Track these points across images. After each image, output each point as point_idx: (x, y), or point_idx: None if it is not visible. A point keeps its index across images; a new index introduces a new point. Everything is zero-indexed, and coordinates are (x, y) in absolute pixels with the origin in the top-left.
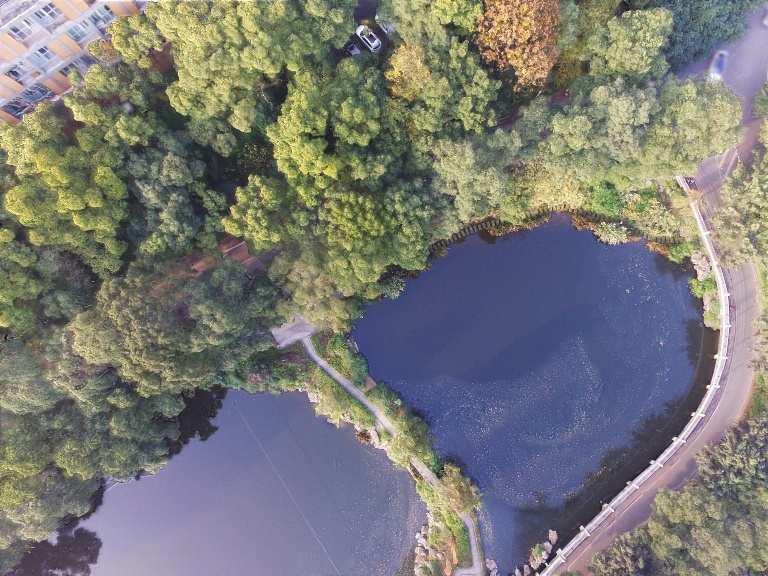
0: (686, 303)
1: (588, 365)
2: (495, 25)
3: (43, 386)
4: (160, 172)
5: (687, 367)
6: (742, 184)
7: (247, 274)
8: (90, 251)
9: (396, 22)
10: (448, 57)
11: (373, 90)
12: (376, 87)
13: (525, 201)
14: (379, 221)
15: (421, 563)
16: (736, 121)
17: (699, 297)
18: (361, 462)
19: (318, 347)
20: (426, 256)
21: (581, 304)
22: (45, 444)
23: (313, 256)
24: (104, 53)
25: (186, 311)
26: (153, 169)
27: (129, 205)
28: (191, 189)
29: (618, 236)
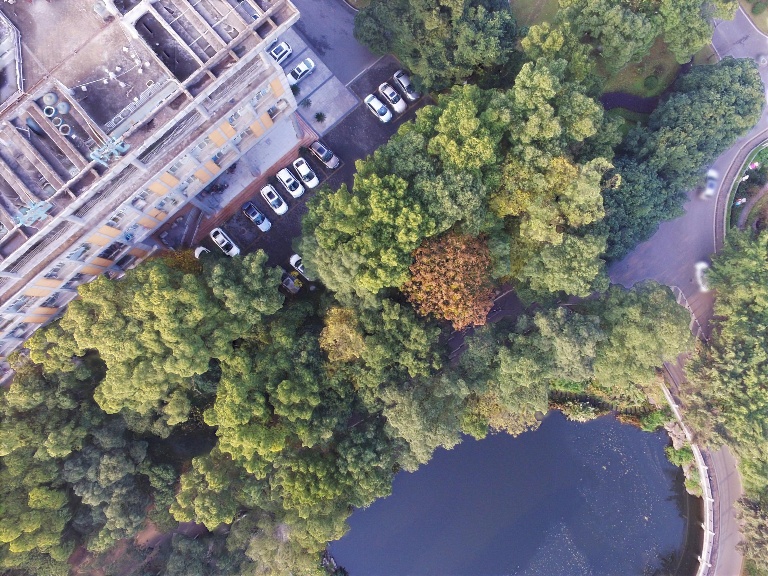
0: (665, 472)
1: (574, 551)
2: (424, 289)
3: None
4: (98, 475)
5: (677, 518)
6: (703, 365)
7: None
8: (34, 564)
9: None
10: (382, 317)
11: (309, 361)
12: (311, 358)
13: (484, 422)
14: (333, 486)
15: None
16: (684, 340)
17: (678, 466)
18: None
19: (294, 571)
20: (390, 483)
21: (559, 487)
22: None
23: (270, 526)
24: (24, 368)
25: None
26: (90, 475)
27: (70, 509)
28: (135, 471)
29: (586, 415)
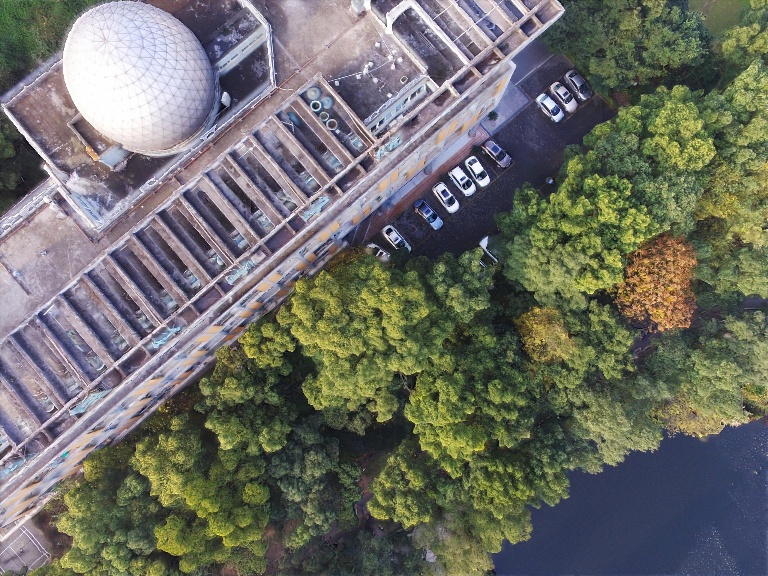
0: None
1: (726, 555)
2: (638, 291)
3: None
4: (303, 471)
5: None
6: None
7: (378, 524)
8: (235, 558)
9: (524, 280)
10: (586, 318)
11: (514, 361)
12: (517, 358)
13: (662, 425)
14: (529, 486)
15: None
16: None
17: None
18: None
19: None
20: None
21: (710, 491)
22: None
23: (461, 525)
24: (237, 362)
25: None
26: (296, 471)
27: None
28: None
29: (741, 420)
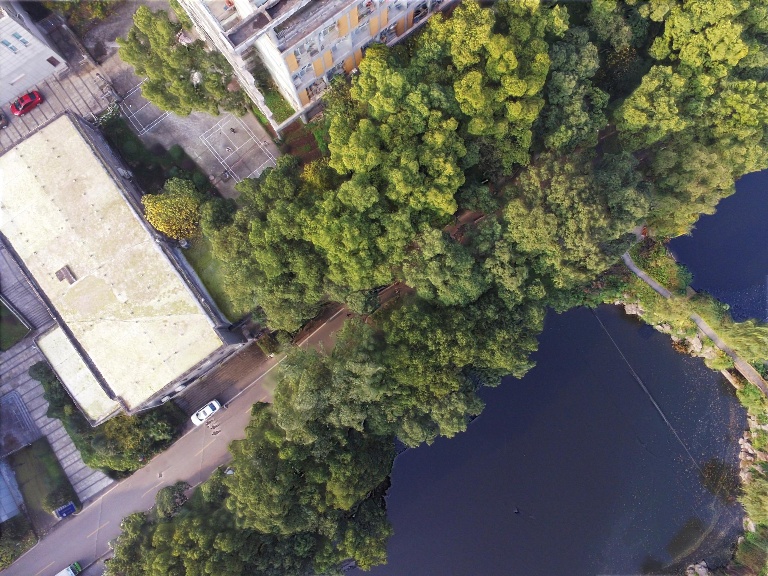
0: None
1: None
2: None
3: (479, 274)
4: (578, 63)
5: None
6: None
7: None
8: (506, 144)
9: None
10: None
11: None
12: None
13: None
14: None
15: (747, 467)
16: None
17: None
18: (678, 372)
19: (639, 258)
20: None
21: None
22: (473, 335)
23: (704, 147)
24: None
25: (605, 199)
26: (574, 59)
27: None
28: None
29: None
